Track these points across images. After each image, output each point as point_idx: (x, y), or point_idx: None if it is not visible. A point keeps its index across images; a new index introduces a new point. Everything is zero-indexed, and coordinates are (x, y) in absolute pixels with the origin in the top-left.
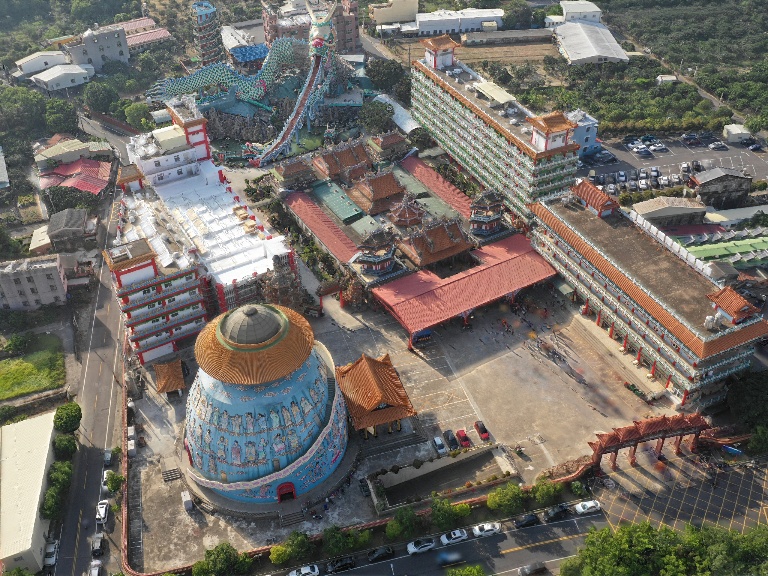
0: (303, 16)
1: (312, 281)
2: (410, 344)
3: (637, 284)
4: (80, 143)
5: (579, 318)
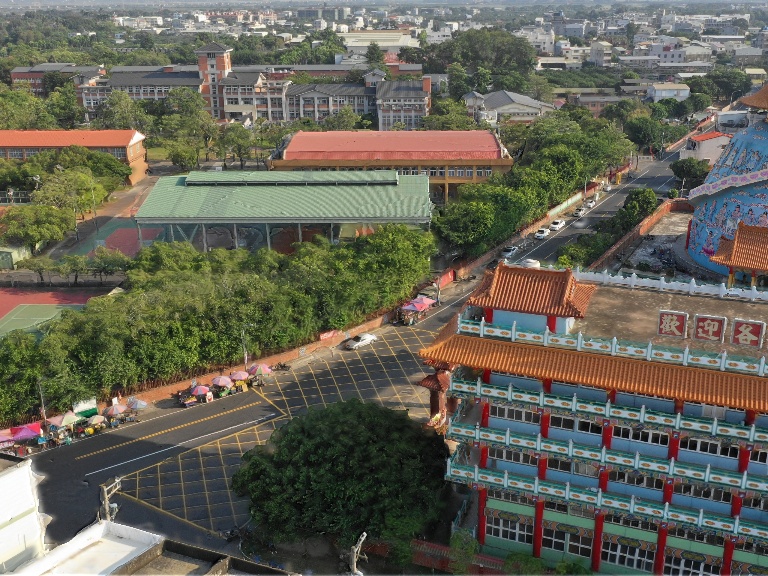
0: None
1: None
2: None
3: (740, 292)
4: None
5: None
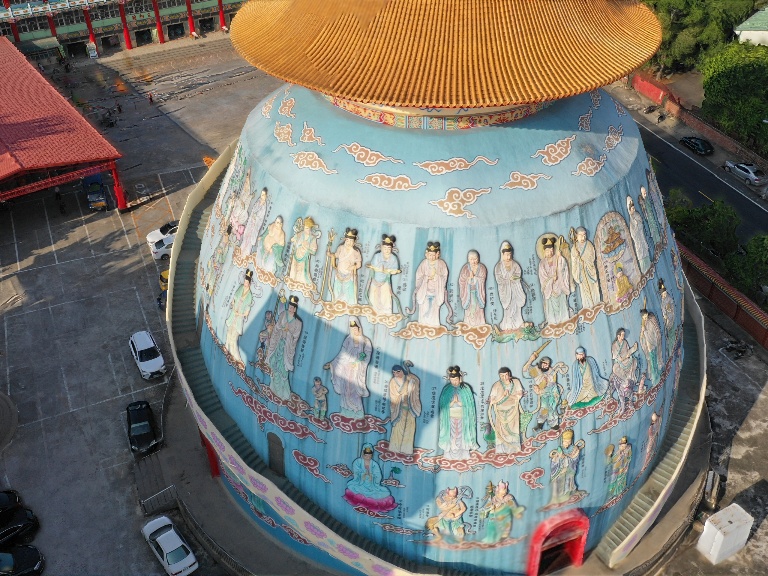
0: None
1: None
2: (122, 197)
3: None
4: None
5: (107, 60)
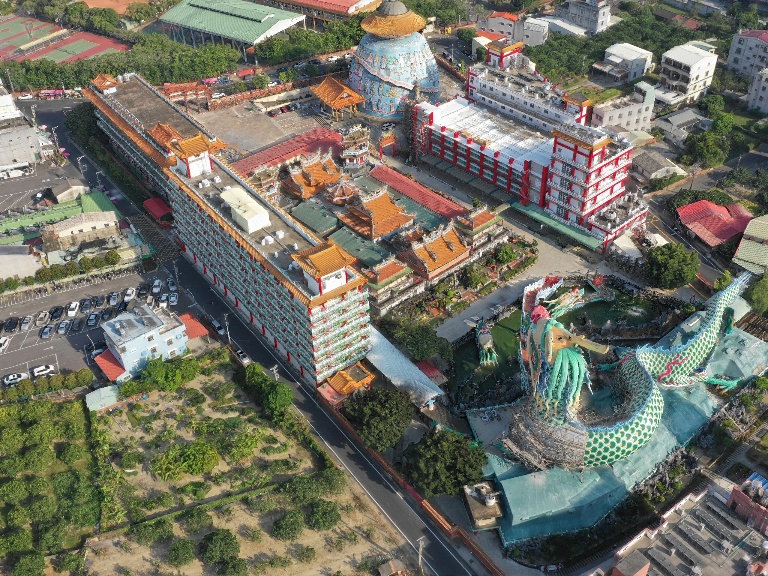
0: (711, 570)
1: (414, 176)
2: None
3: None
4: (761, 235)
5: None
